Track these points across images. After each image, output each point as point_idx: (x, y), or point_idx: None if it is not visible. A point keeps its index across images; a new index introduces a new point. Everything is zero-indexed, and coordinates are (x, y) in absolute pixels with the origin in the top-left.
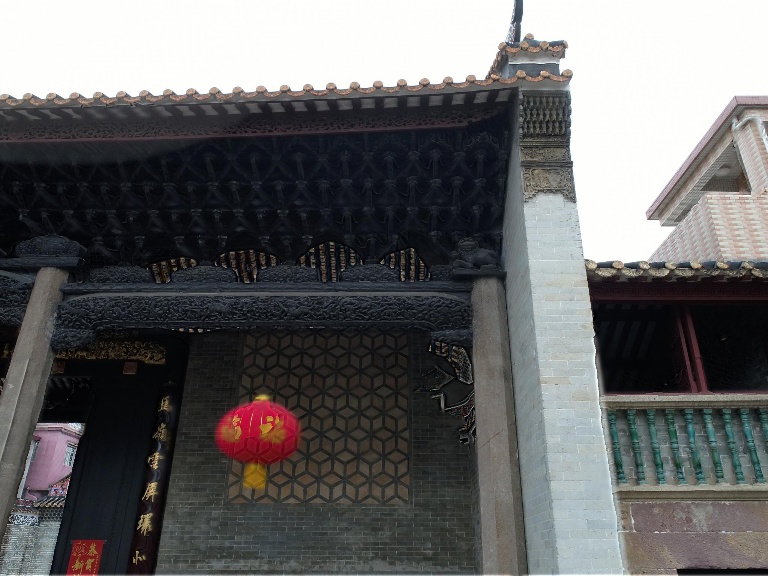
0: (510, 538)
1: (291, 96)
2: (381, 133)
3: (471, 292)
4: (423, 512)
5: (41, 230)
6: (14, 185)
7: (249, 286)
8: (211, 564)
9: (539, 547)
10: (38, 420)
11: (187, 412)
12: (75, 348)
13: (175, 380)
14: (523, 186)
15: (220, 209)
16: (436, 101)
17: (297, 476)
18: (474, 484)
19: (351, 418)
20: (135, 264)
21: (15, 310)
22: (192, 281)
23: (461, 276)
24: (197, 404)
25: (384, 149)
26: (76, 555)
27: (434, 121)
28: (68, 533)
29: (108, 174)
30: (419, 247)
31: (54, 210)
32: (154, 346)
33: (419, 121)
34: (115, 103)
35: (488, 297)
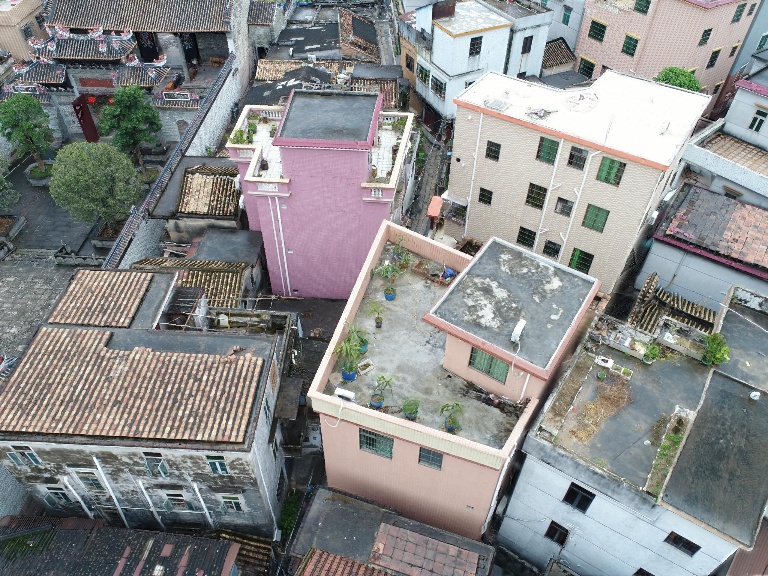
0: None
1: None
2: None
3: None
4: None
5: None
6: None
7: None
8: None
9: None
10: None
11: None
12: None
13: None
14: None
15: None
16: None
17: None
18: None
19: None
20: None
21: None
22: None
23: None
24: None
25: None
26: None
27: None
28: None
29: None
30: None
31: None
32: None
33: None
34: None
35: None
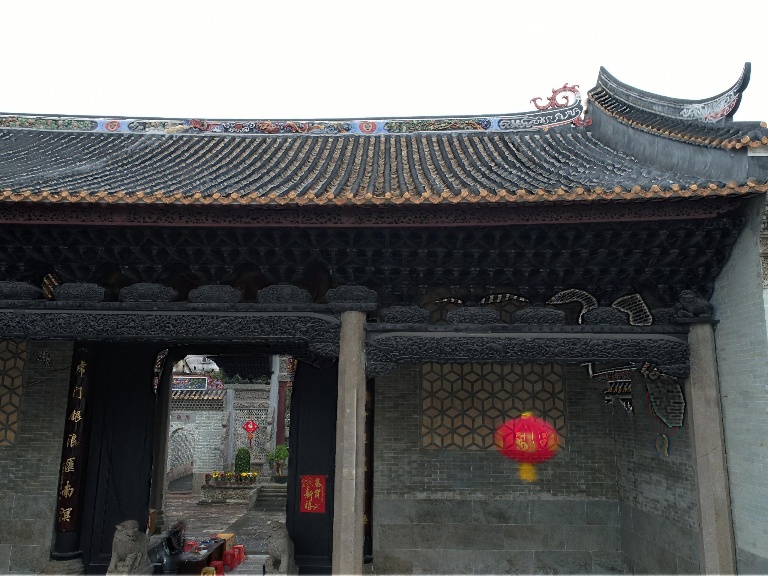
0: (725, 523)
1: (584, 198)
2: (645, 221)
3: (688, 334)
4: (577, 456)
5: (344, 280)
6: (332, 251)
7: (514, 328)
8: (416, 495)
9: (758, 537)
10: (195, 353)
11: None
12: None
13: None
14: (762, 274)
15: (494, 268)
16: (695, 198)
17: (476, 428)
18: (623, 439)
19: (516, 382)
20: (414, 304)
21: (330, 345)
22: (465, 321)
23: (683, 323)
24: None
25: (641, 230)
26: (305, 486)
27: (689, 212)
28: (296, 470)
29: (412, 244)
30: (643, 293)
31: (357, 266)
32: None
33: (677, 212)
34: (440, 201)
35: (704, 341)
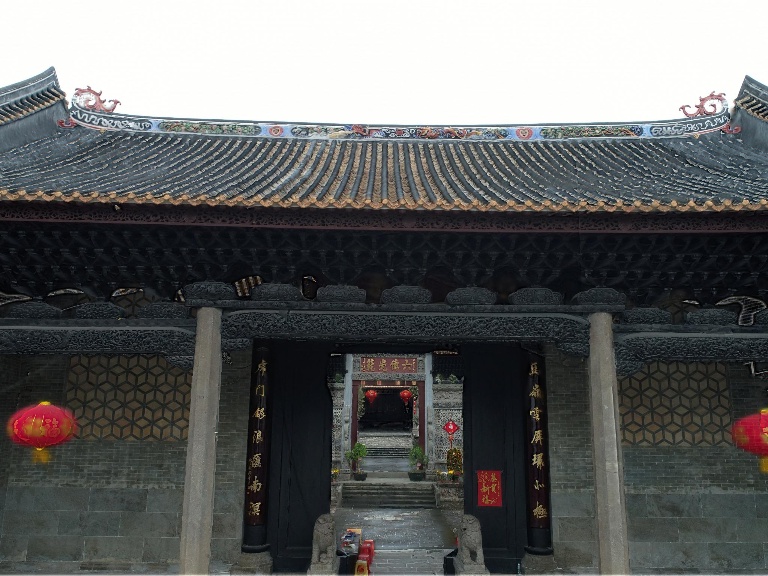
0: None
1: None
2: None
3: None
4: (745, 452)
5: (595, 283)
6: (595, 255)
7: (754, 329)
8: (592, 489)
9: None
10: None
11: (552, 375)
12: None
13: None
14: None
15: (742, 272)
16: None
17: (646, 425)
18: None
19: (682, 380)
20: (655, 306)
21: (581, 345)
22: (706, 322)
23: None
24: (558, 368)
25: None
26: (482, 481)
27: None
28: (472, 465)
29: (673, 250)
30: None
31: (610, 270)
32: None
33: None
34: None
35: None
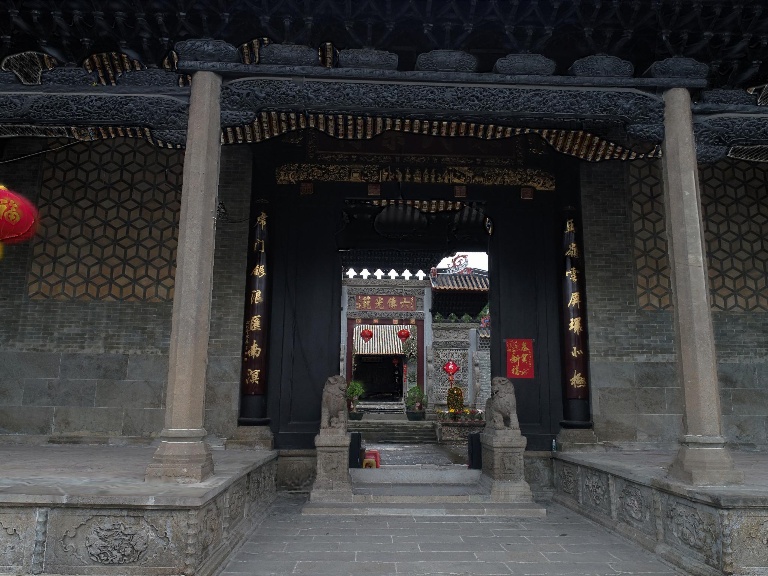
0: None
1: None
2: None
3: None
4: None
5: (672, 51)
6: (677, 5)
7: None
8: (635, 357)
9: None
10: None
11: (589, 234)
12: (473, 174)
13: (574, 205)
14: None
15: None
16: None
17: None
18: None
19: (734, 241)
20: (738, 88)
21: (654, 127)
22: None
23: None
24: (597, 227)
25: None
26: (511, 351)
27: None
28: (500, 333)
29: None
30: None
31: (692, 32)
32: (545, 174)
33: None
34: None
35: None
